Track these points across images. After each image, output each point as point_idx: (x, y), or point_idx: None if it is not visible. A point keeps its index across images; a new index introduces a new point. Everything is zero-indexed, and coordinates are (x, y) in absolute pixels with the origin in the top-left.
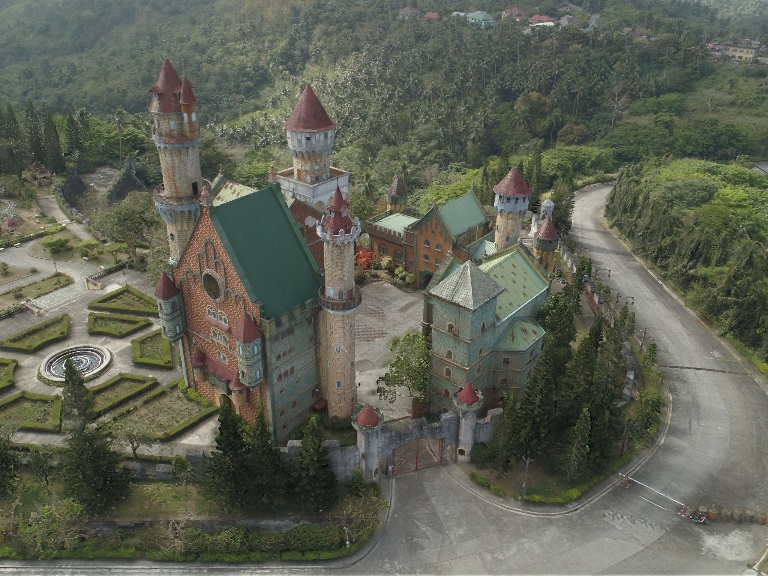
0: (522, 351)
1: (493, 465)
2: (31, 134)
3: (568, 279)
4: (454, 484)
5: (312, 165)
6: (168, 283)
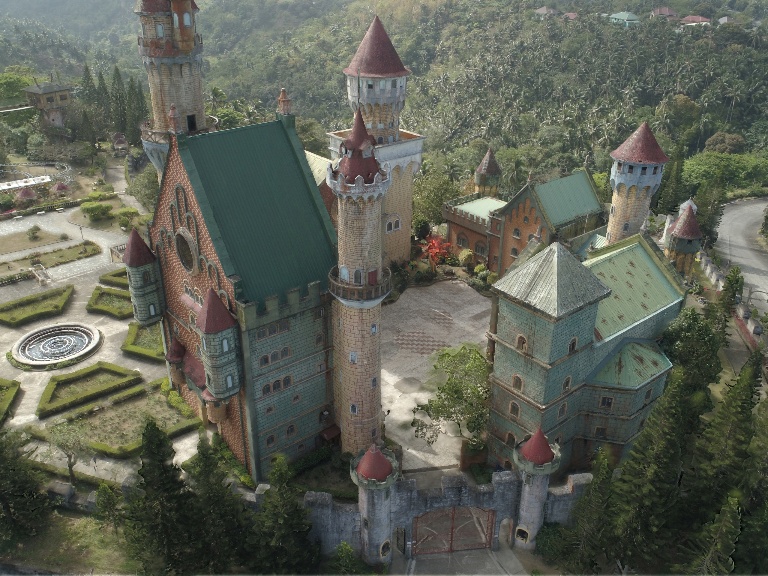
0: (632, 389)
1: (567, 566)
2: (116, 103)
3: (710, 298)
4: None
5: (375, 122)
6: (139, 245)
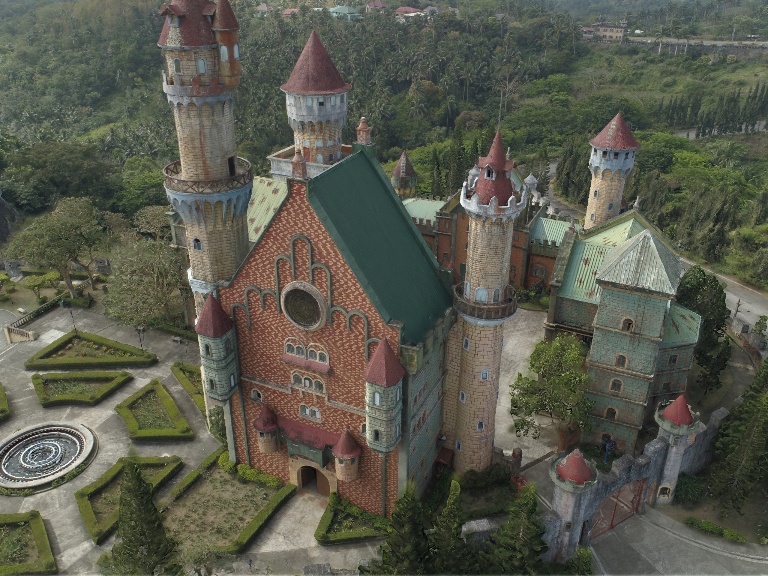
0: (693, 343)
1: (732, 504)
2: None
3: None
4: (670, 538)
5: (325, 140)
6: (219, 312)
